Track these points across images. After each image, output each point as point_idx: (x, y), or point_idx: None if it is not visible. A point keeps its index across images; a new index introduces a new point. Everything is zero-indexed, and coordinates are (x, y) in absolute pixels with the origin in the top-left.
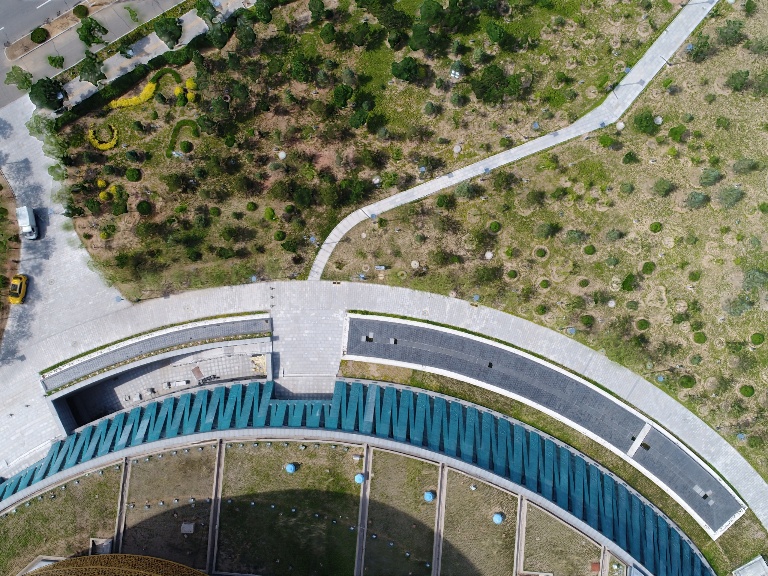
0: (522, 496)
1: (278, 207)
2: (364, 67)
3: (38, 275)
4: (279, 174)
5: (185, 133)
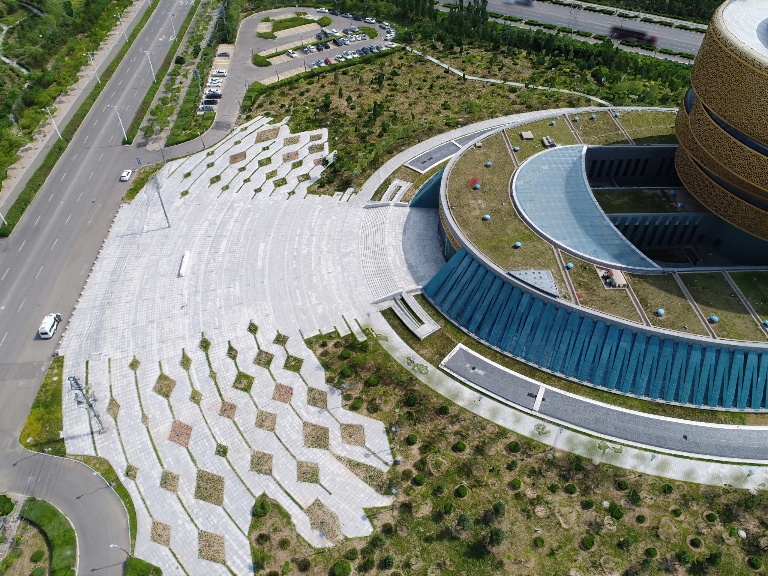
0: None
1: None
2: None
3: None
4: None
5: None
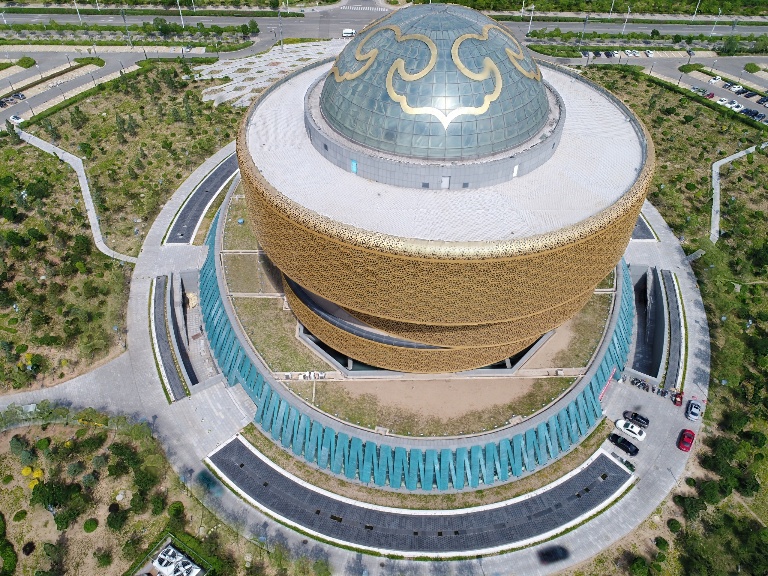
0: None
1: (79, 278)
2: None
3: None
4: (56, 279)
5: (2, 323)
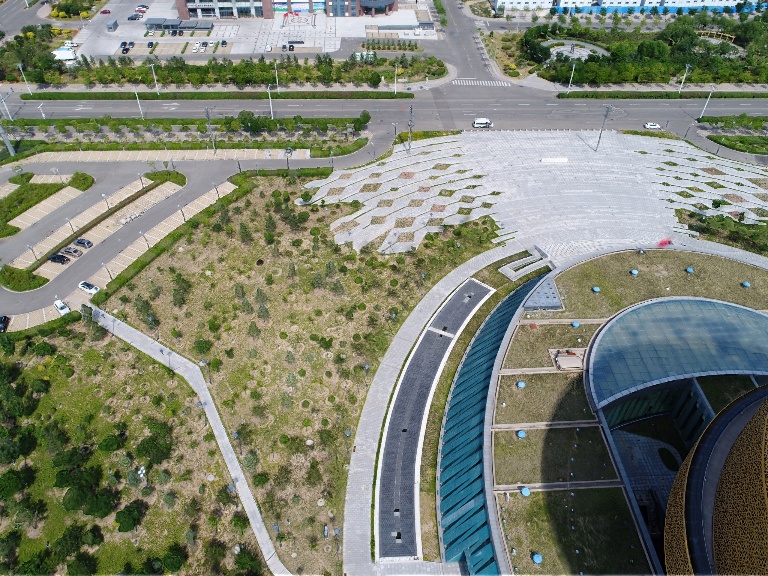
0: (499, 373)
1: None
2: (113, 573)
3: None
4: None
5: None
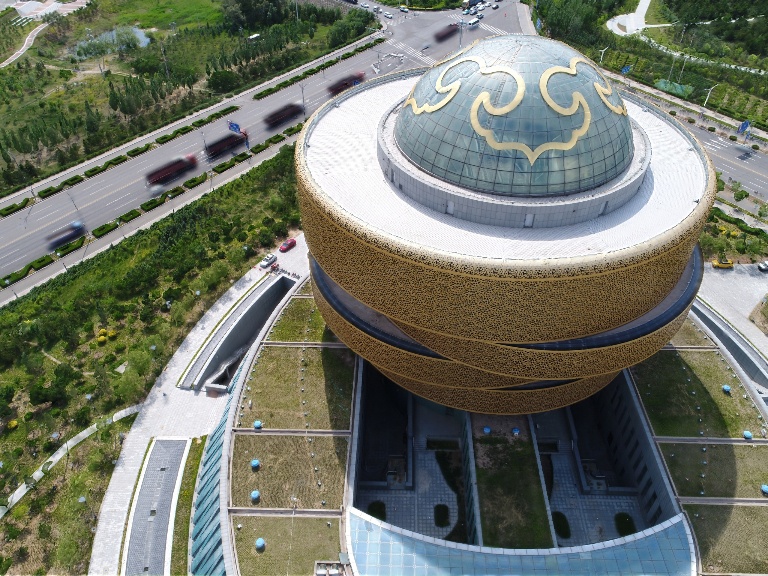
0: None
1: None
2: None
3: (737, 273)
4: None
5: None
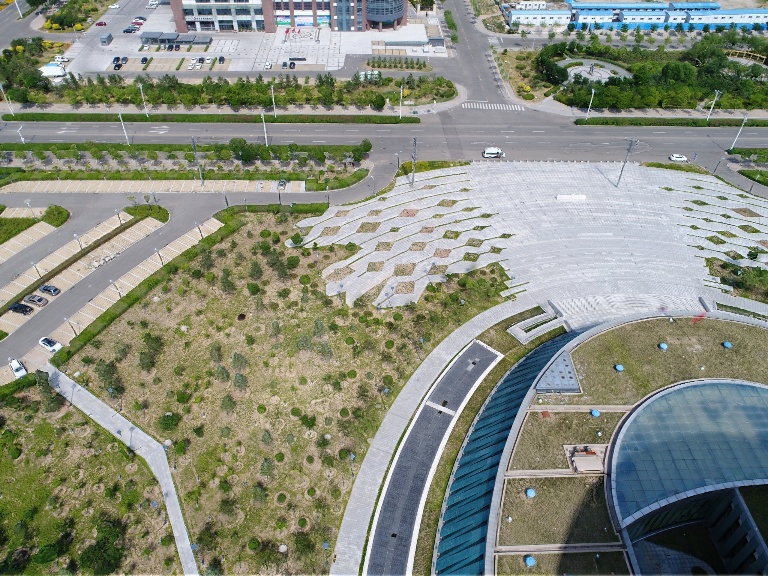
0: (505, 476)
1: None
2: None
3: None
4: None
5: None
